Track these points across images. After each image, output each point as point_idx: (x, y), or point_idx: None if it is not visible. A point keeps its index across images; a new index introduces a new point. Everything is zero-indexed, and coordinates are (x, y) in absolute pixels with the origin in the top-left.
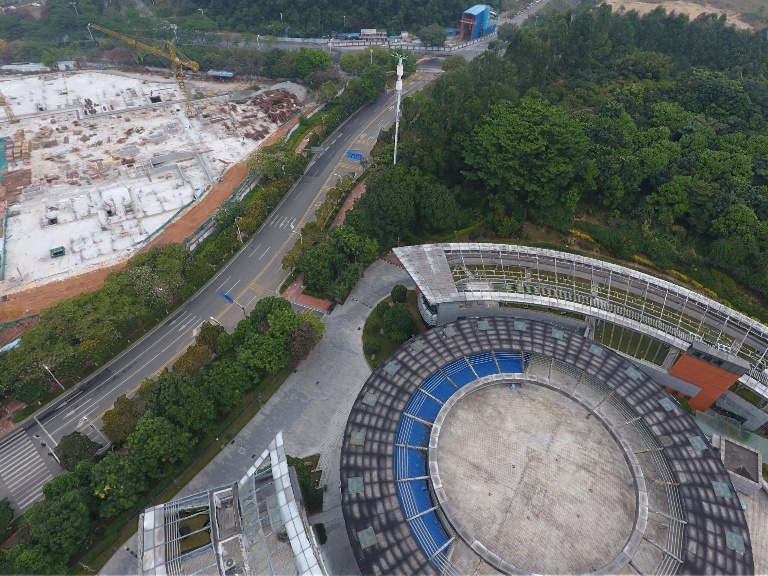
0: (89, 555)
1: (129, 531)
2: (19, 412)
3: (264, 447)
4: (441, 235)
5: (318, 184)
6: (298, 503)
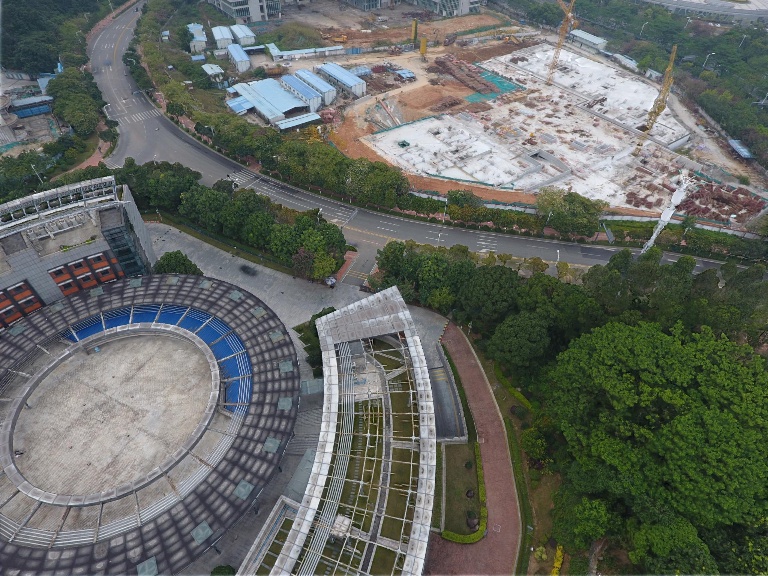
0: (168, 215)
1: (181, 227)
2: (265, 170)
3: (227, 272)
4: (504, 372)
5: (569, 259)
6: (99, 230)
